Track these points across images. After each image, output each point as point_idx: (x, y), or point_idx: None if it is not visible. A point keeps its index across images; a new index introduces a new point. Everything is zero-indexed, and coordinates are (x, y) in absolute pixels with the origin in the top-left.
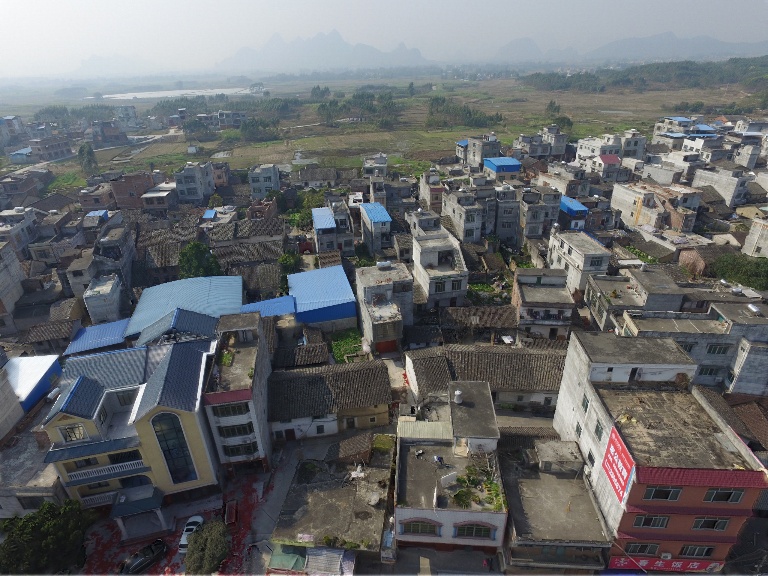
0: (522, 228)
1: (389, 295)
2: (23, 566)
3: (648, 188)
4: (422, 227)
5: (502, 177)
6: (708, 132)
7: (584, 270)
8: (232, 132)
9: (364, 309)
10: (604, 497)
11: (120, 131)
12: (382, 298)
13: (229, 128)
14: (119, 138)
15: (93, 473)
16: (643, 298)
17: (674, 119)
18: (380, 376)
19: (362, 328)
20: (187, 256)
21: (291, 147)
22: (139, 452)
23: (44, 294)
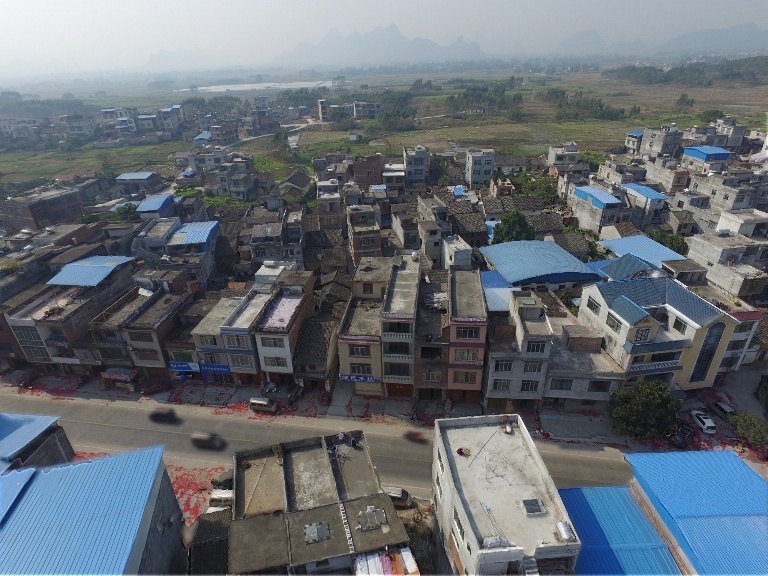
0: None
1: (740, 257)
2: (652, 421)
3: None
4: (691, 205)
5: None
6: None
7: None
8: (371, 122)
9: (715, 268)
10: None
11: (274, 120)
12: (736, 259)
13: (366, 118)
14: (274, 126)
15: (645, 367)
16: None
17: None
18: None
19: None
20: (509, 222)
21: (438, 136)
22: (681, 353)
23: (393, 250)
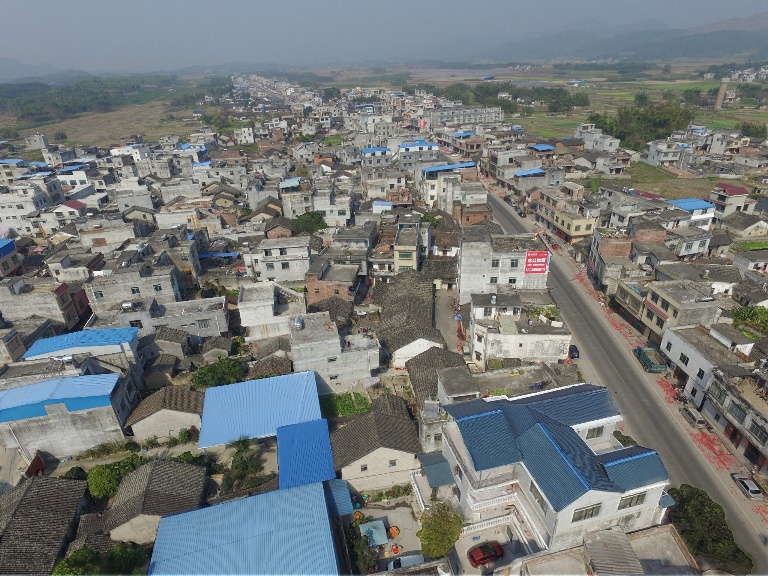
0: (187, 272)
1: None
2: None
3: (180, 207)
4: None
5: (4, 264)
6: (46, 167)
7: (308, 256)
8: None
9: (341, 360)
10: (532, 284)
11: None
12: None
13: None
14: None
15: None
16: (355, 247)
17: (9, 162)
18: (444, 352)
19: (325, 391)
20: None
21: None
22: None
23: None
